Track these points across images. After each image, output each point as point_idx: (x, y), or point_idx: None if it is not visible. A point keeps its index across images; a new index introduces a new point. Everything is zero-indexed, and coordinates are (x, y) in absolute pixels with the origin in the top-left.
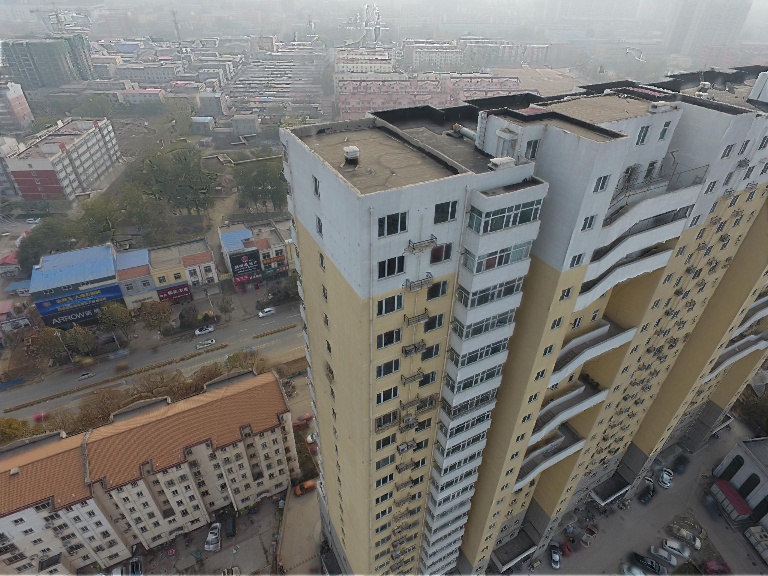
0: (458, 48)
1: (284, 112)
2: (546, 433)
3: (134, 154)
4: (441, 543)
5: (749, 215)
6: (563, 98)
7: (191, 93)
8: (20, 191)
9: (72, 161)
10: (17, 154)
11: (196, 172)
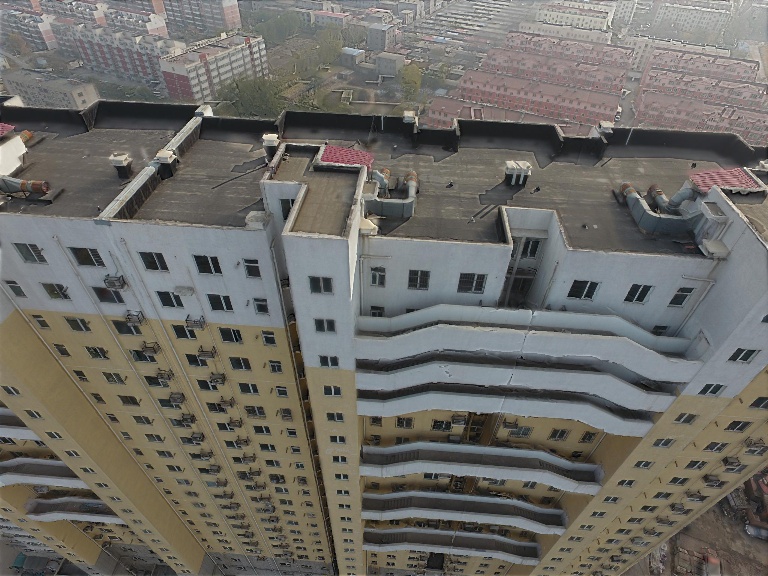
0: (742, 8)
1: (442, 57)
2: (7, 484)
3: (282, 74)
4: (0, 522)
5: (261, 363)
6: (48, 113)
7: (372, 22)
8: (167, 89)
9: (210, 71)
10: (172, 57)
11: (269, 103)
